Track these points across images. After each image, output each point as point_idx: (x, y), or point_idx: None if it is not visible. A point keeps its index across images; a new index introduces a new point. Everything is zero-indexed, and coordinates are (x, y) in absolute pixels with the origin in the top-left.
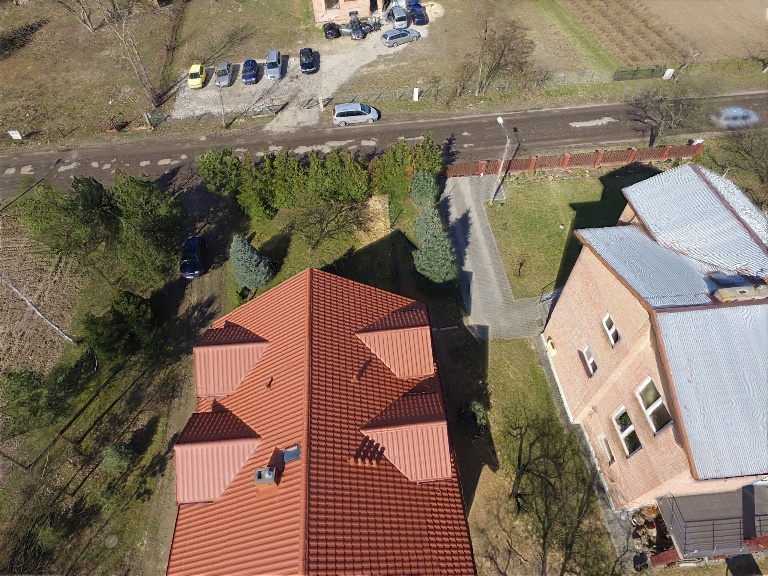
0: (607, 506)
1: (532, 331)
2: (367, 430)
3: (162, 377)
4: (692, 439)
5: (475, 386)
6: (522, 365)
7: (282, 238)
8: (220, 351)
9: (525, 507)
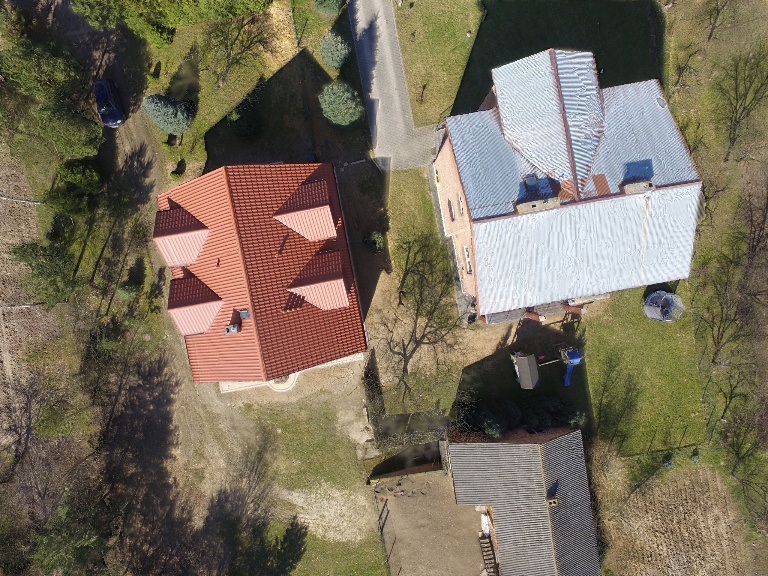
0: (459, 289)
1: (426, 160)
2: (291, 289)
3: (131, 226)
4: (481, 296)
5: (378, 213)
6: (415, 192)
7: (190, 68)
8: (174, 239)
9: (407, 294)
